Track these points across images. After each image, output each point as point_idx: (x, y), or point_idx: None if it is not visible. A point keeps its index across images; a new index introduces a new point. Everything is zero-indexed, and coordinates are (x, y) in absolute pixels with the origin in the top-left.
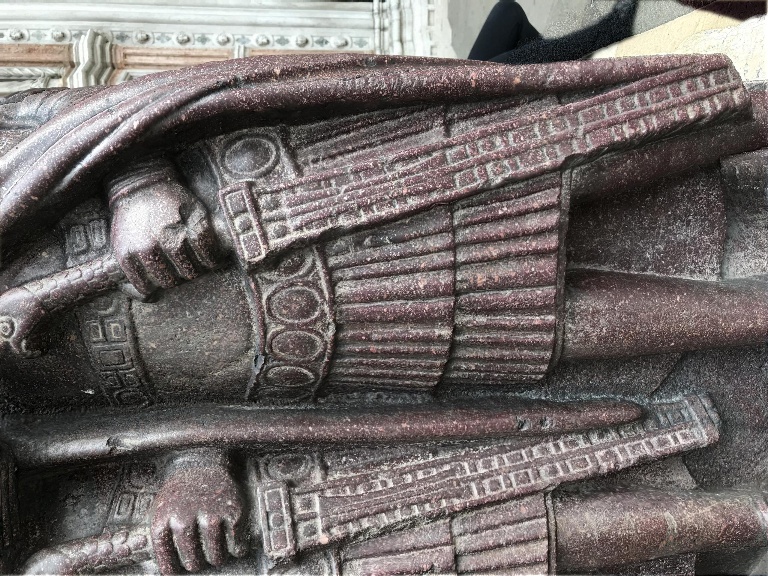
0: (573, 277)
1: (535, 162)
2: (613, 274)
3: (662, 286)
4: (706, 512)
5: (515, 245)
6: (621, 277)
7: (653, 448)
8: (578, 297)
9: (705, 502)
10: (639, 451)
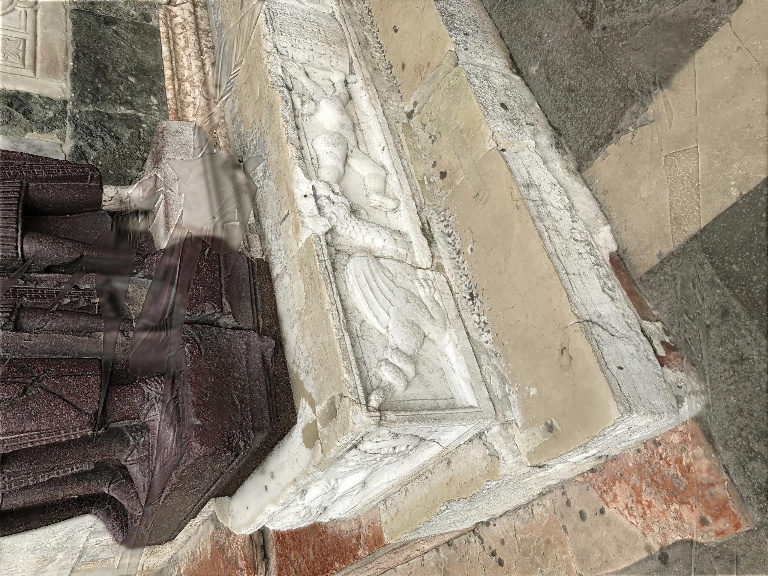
0: None
1: None
2: None
3: (63, 449)
4: (80, 489)
5: None
6: (43, 445)
7: (59, 474)
8: (13, 462)
9: (82, 484)
10: (51, 476)
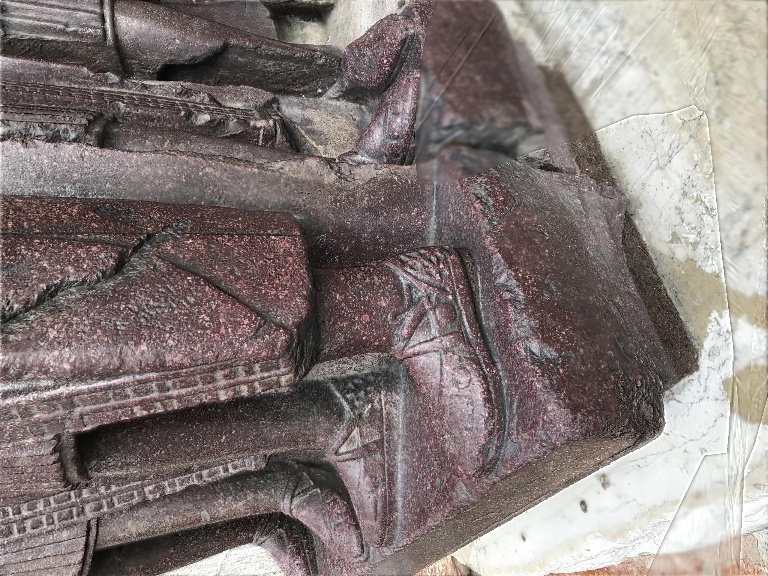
0: (111, 427)
1: (14, 439)
2: (163, 413)
3: (212, 425)
4: (239, 506)
5: (7, 469)
6: (170, 418)
7: (202, 479)
8: (107, 456)
9: (243, 496)
10: (187, 483)
